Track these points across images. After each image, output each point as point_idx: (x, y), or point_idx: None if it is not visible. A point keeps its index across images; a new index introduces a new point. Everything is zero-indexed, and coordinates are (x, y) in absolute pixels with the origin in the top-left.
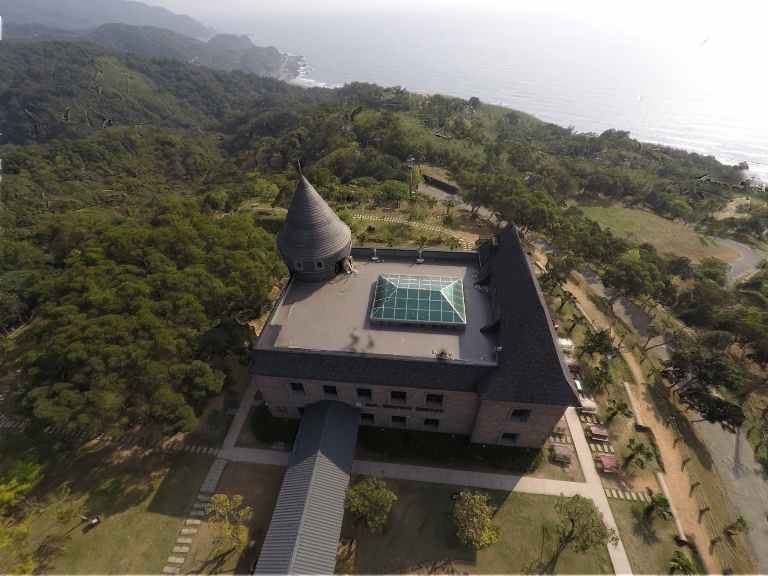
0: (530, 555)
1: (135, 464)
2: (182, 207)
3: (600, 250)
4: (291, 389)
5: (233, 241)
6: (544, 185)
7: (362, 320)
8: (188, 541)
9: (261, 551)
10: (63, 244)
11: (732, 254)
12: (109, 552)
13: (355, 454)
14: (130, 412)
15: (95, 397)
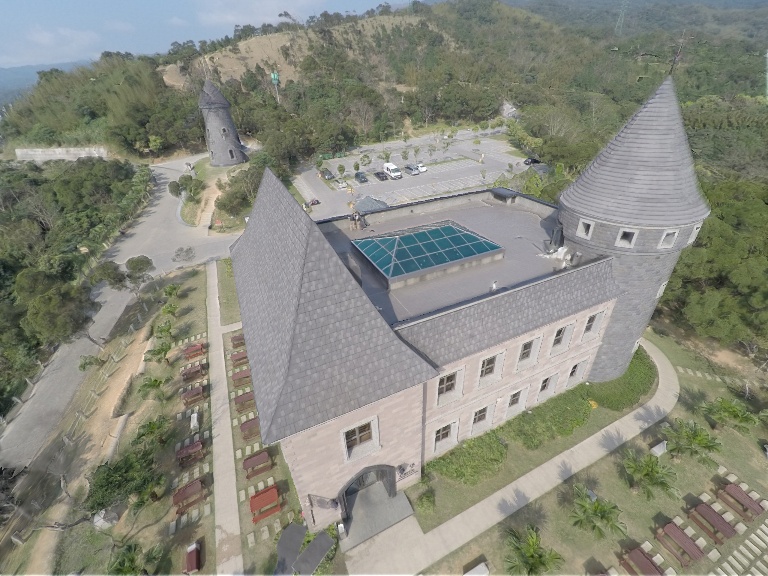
0: None
1: None
2: None
3: None
4: None
5: None
6: None
7: None
8: None
9: None
10: None
11: None
12: None
13: None
14: None
15: None
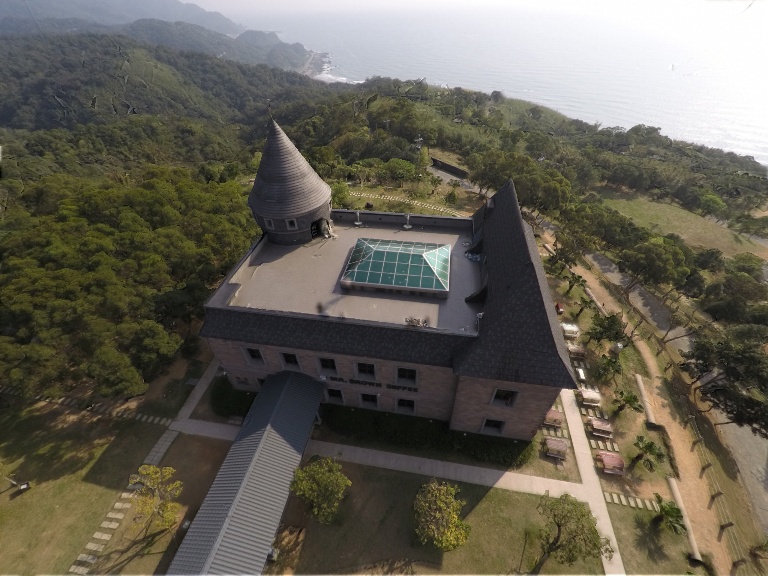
0: (507, 563)
1: (79, 430)
2: (172, 175)
3: (617, 232)
4: (249, 357)
5: (214, 205)
6: None
7: (332, 284)
8: (119, 516)
9: (187, 532)
10: (47, 206)
11: None
12: (33, 522)
13: (318, 434)
14: (74, 372)
15: (33, 352)
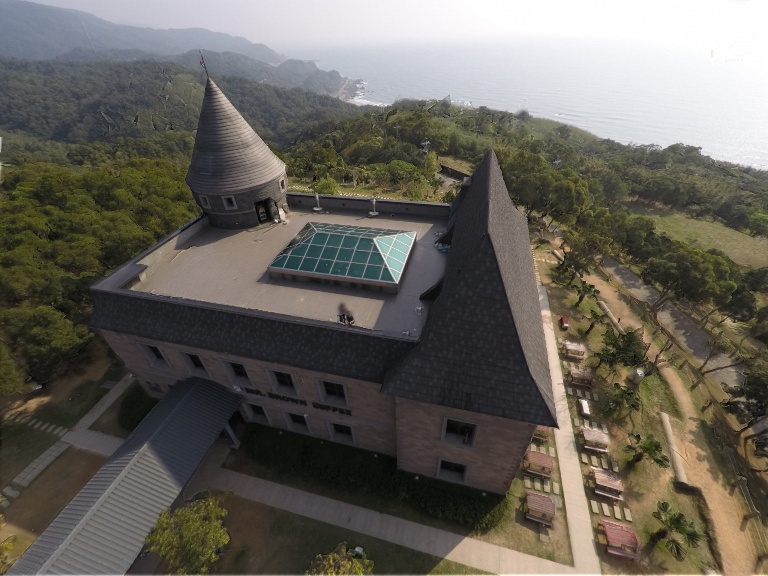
0: None
1: None
2: (156, 167)
3: (642, 237)
4: (154, 356)
5: (177, 192)
6: None
7: (261, 271)
8: None
9: None
10: None
11: None
12: None
13: (232, 462)
14: None
15: None
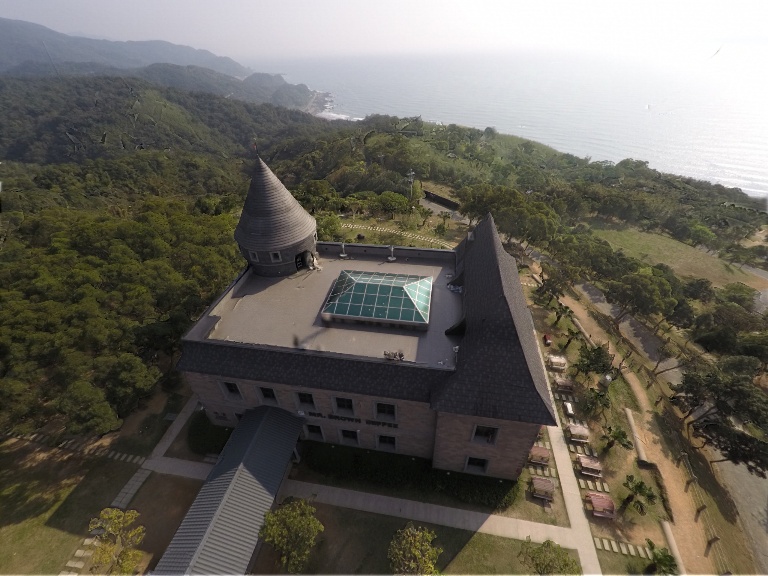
0: None
1: (48, 468)
2: (168, 208)
3: (603, 262)
4: (227, 391)
5: (205, 238)
6: (553, 206)
7: (313, 316)
8: (79, 565)
9: None
10: (42, 238)
11: (762, 283)
12: None
13: (296, 473)
14: (47, 407)
15: (5, 386)
